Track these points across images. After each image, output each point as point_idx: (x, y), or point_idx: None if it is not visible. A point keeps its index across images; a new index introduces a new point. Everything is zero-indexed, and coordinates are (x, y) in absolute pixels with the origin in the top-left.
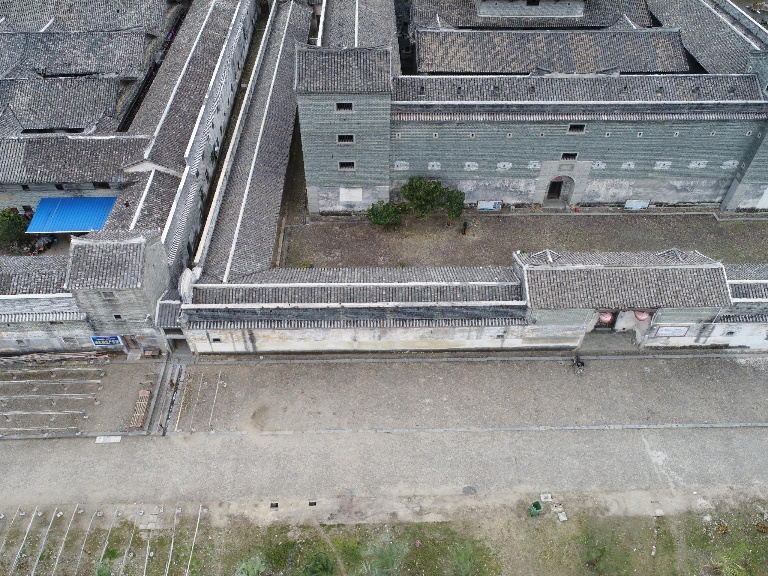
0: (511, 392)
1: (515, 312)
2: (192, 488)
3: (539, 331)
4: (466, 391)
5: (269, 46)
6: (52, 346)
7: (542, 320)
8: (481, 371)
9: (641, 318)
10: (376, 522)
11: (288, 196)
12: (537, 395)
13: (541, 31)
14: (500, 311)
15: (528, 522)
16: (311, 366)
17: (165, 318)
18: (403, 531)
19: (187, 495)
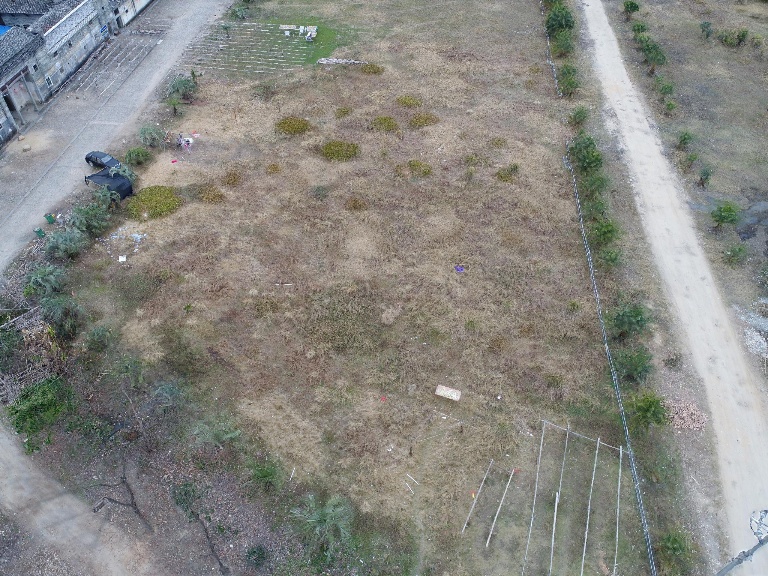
0: None
1: None
2: (197, 27)
3: None
4: None
5: None
6: (93, 46)
7: None
8: None
9: None
10: None
11: None
12: None
13: None
14: None
15: None
16: (154, 8)
17: (111, 4)
18: None
19: (200, 28)
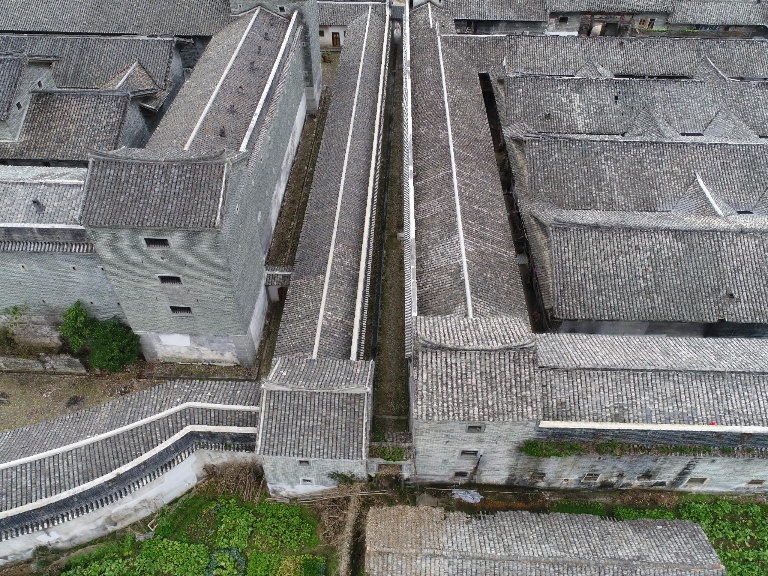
0: None
1: None
2: None
3: None
4: None
5: (361, 230)
6: None
7: None
8: None
9: None
10: None
11: None
12: None
13: (35, 35)
14: None
15: None
16: None
17: None
18: None
19: None
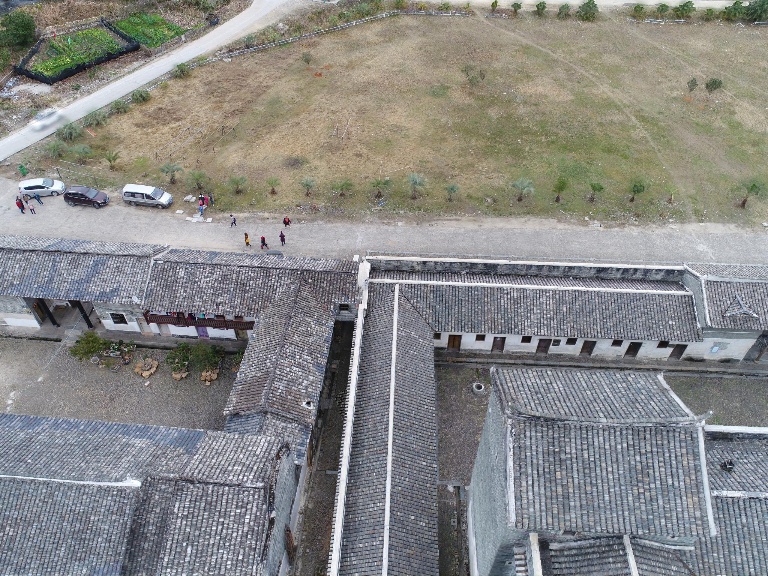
0: None
1: None
2: None
3: None
4: None
5: None
6: None
7: None
8: None
9: None
10: None
11: None
12: None
13: None
14: None
15: None
16: None
17: None
18: None
19: None
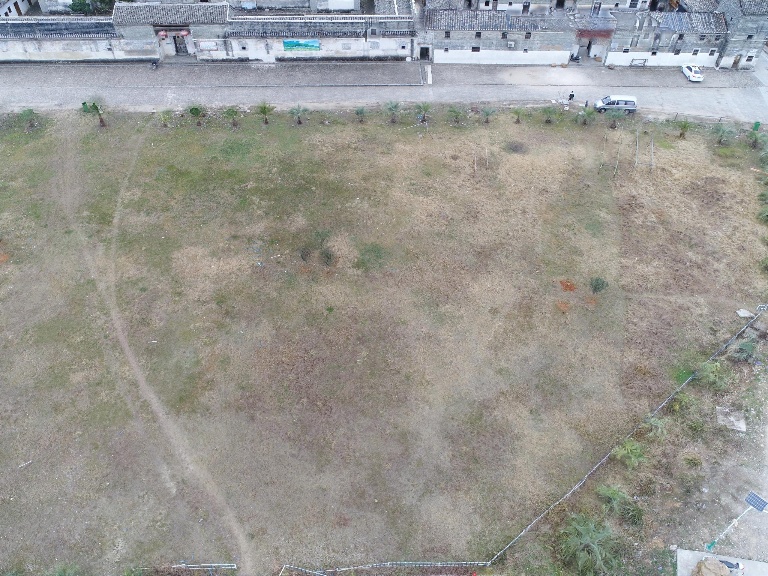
0: (110, 76)
1: (108, 28)
2: None
3: (130, 45)
4: (85, 76)
5: None
6: None
7: (127, 35)
8: (99, 69)
9: (183, 34)
10: (1, 113)
11: (36, 7)
12: (124, 77)
13: None
14: (99, 27)
15: (81, 113)
16: (3, 68)
17: None
18: (13, 116)
19: None
